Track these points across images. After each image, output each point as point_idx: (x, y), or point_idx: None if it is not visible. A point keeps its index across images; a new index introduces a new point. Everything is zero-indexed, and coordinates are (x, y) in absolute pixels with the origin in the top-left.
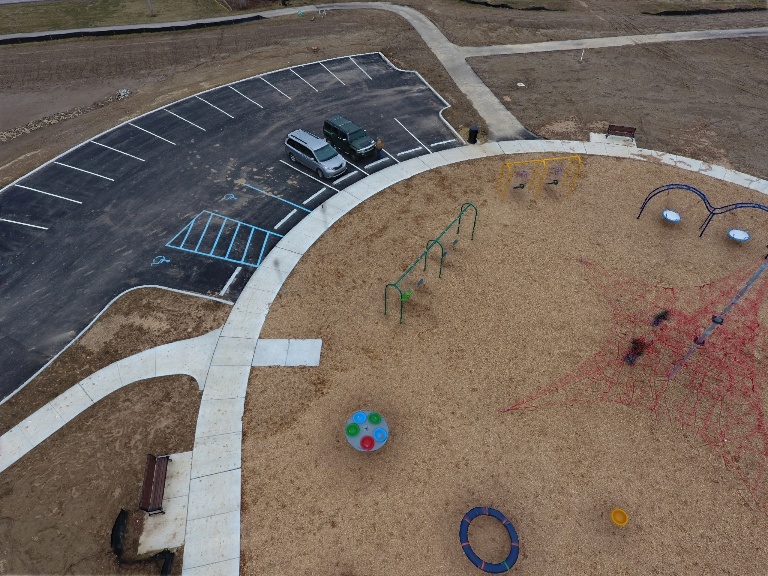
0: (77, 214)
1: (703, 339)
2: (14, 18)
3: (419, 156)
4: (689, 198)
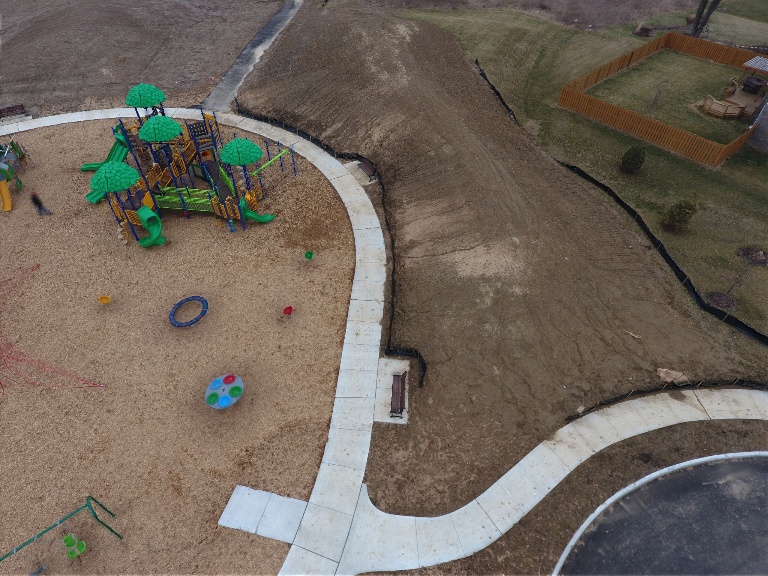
0: None
1: None
2: None
3: None
4: None
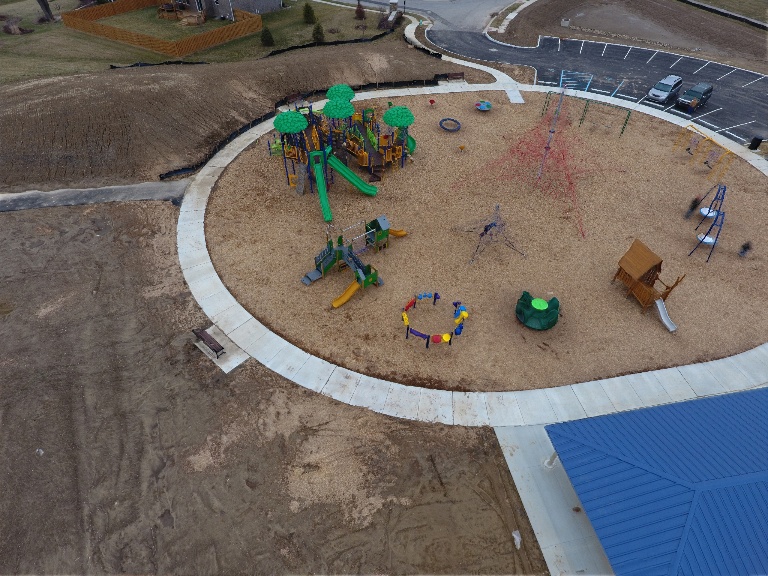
0: (572, 54)
1: (548, 145)
2: (743, 4)
3: (705, 127)
4: (759, 240)
